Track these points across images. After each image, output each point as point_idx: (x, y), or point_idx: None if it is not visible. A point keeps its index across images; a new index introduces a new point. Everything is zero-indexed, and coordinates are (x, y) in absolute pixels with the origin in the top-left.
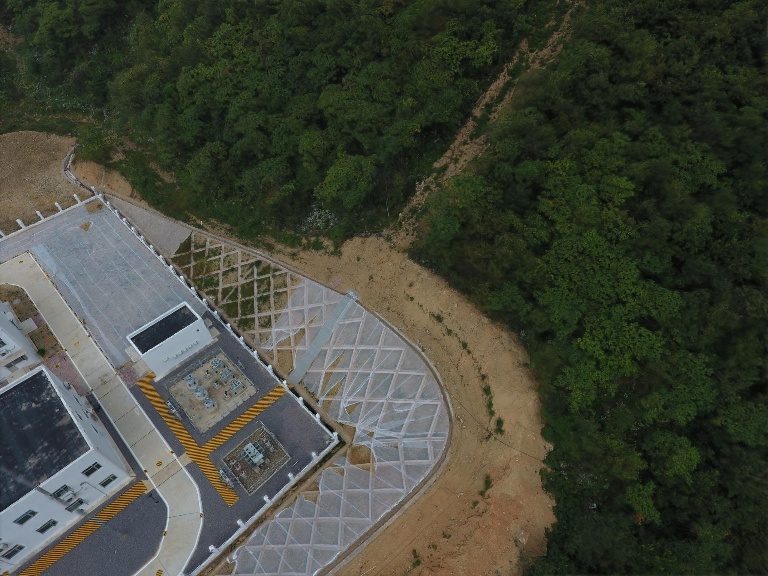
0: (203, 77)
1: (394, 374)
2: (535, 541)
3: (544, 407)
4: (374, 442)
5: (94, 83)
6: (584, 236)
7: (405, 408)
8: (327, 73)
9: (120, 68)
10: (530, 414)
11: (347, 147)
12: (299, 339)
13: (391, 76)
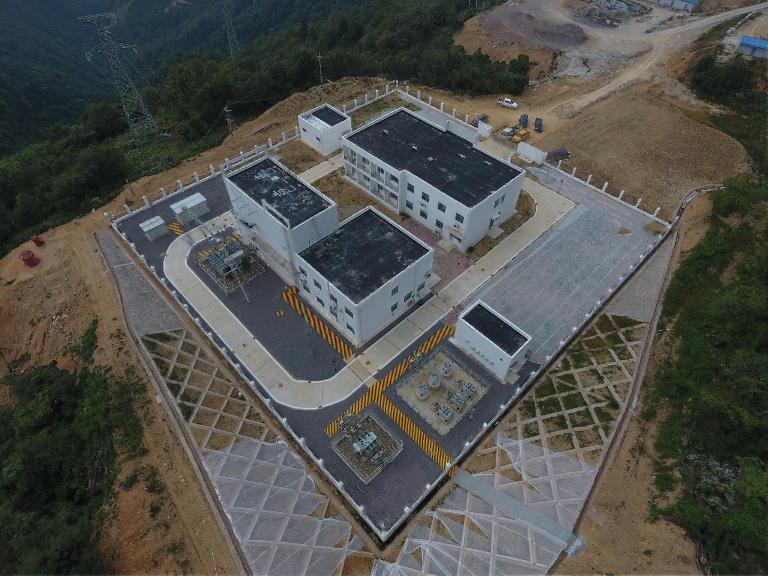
0: None
1: None
2: None
3: None
4: None
5: None
6: None
7: None
8: None
9: None
10: None
11: None
12: (509, 475)
13: None
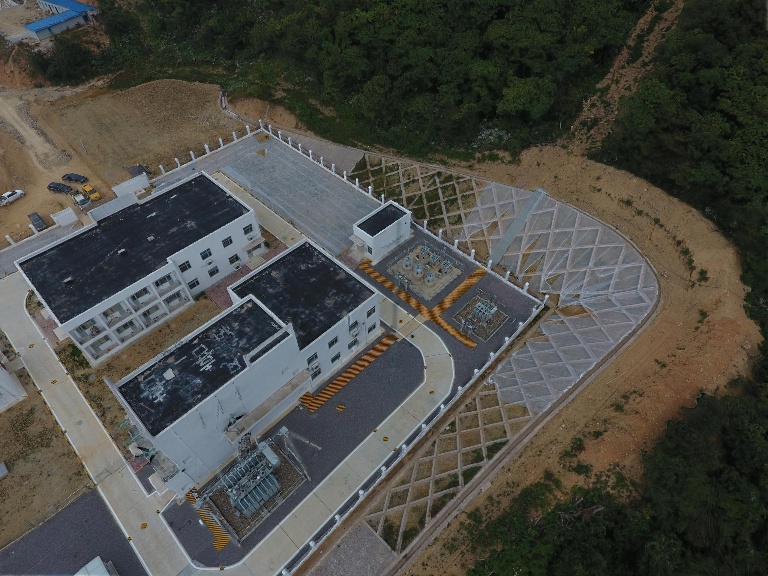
0: (365, 19)
1: (594, 248)
2: (753, 351)
3: (750, 252)
4: (583, 301)
5: (227, 36)
6: (766, 124)
7: (608, 272)
8: (489, 11)
9: (245, 24)
10: (731, 263)
11: (515, 73)
12: (492, 231)
13: (557, 10)
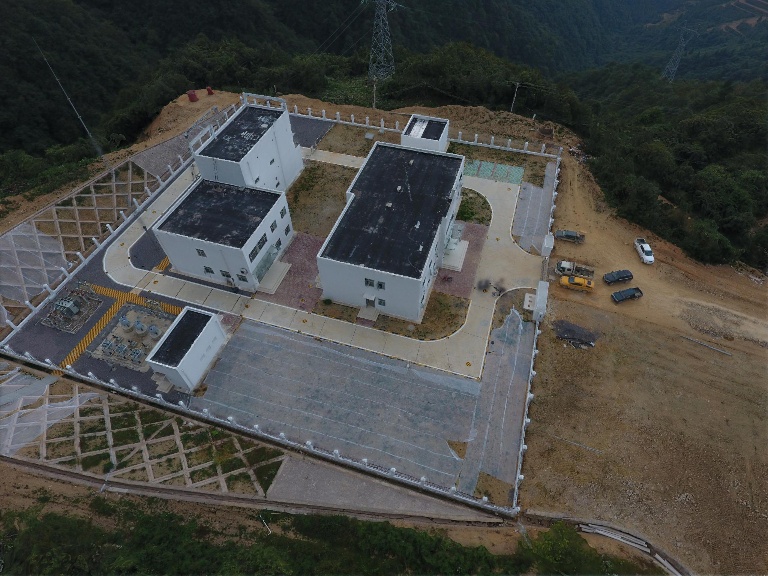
0: None
1: None
2: None
3: None
4: None
5: None
6: None
7: None
8: None
9: None
10: None
11: None
12: (36, 404)
13: None
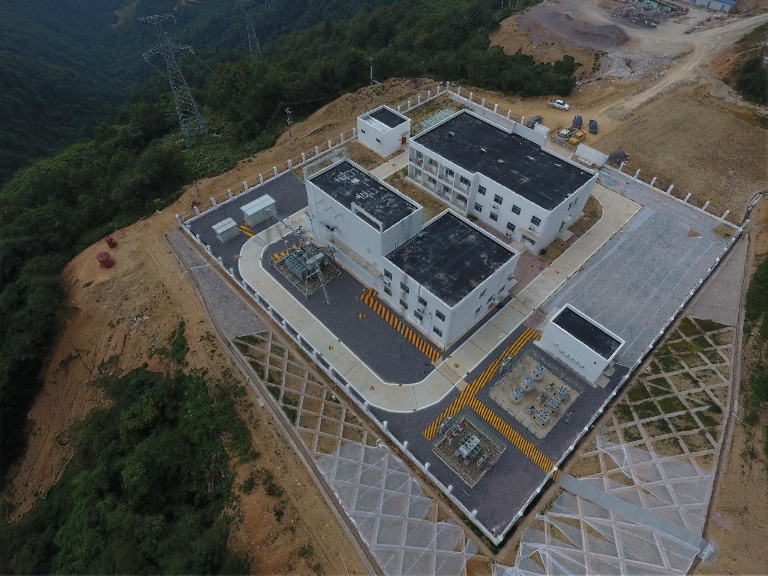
0: None
1: None
2: None
3: None
4: None
5: None
6: None
7: None
8: None
9: None
10: None
11: None
12: (618, 479)
13: None
